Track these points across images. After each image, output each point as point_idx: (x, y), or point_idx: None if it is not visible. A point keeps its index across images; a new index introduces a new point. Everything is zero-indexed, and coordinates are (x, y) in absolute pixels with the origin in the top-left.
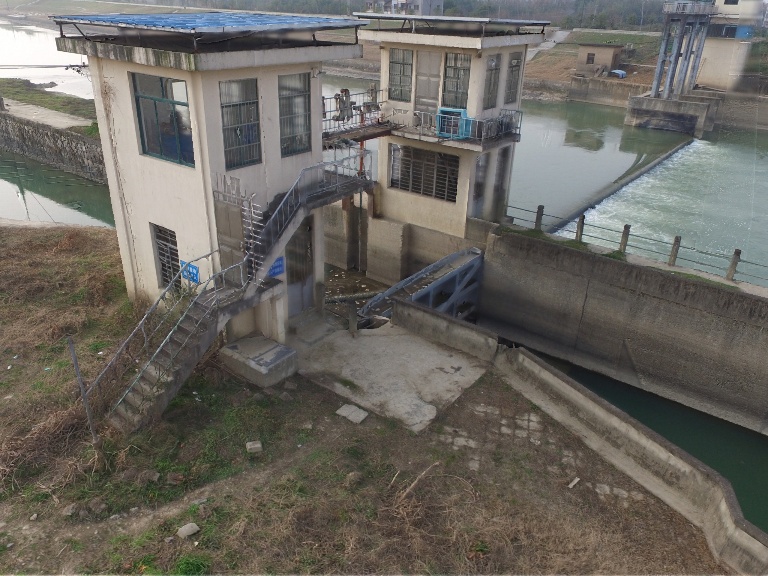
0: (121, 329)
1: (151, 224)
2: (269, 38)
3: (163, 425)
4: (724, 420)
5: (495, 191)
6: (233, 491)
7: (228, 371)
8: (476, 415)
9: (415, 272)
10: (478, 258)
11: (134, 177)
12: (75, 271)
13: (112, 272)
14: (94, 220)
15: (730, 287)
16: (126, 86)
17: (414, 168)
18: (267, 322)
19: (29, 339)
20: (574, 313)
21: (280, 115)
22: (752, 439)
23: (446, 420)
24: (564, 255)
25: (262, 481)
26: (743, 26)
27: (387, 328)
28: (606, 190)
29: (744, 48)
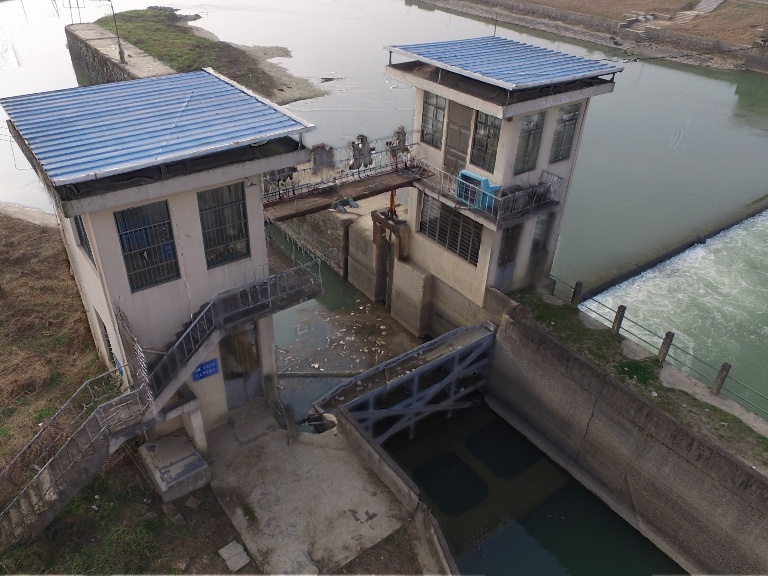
0: None
1: None
2: (175, 162)
3: (34, 548)
4: None
5: (533, 253)
6: None
7: (142, 471)
8: None
9: (436, 324)
10: (489, 336)
11: (78, 262)
12: (72, 305)
13: None
14: None
15: None
16: None
17: (441, 219)
18: None
19: None
20: (578, 427)
21: (203, 229)
22: None
23: None
24: (574, 364)
25: None
26: None
27: (329, 436)
28: (729, 218)
29: None
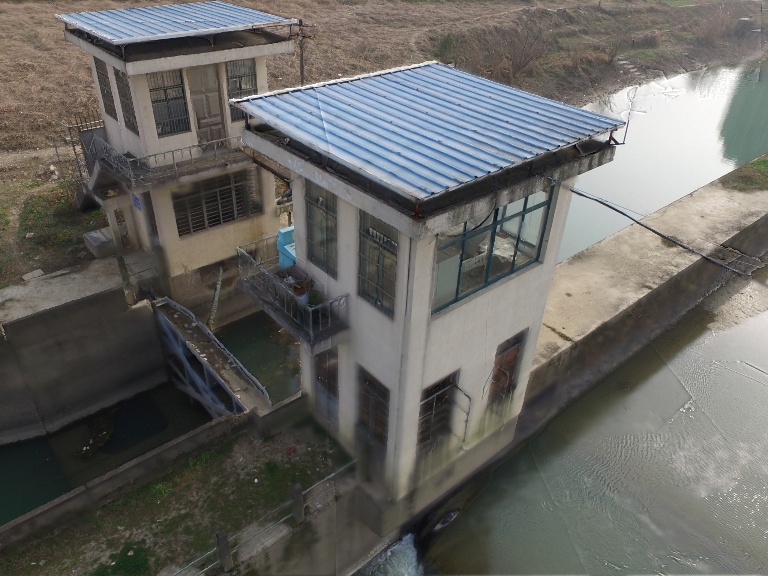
0: None
1: None
2: None
3: None
4: None
5: None
6: (7, 231)
7: None
8: None
9: None
10: None
11: None
12: None
13: None
14: None
15: None
16: None
17: None
18: (130, 230)
19: None
20: None
21: None
22: None
23: None
24: None
25: (6, 240)
26: None
27: None
28: None
29: None
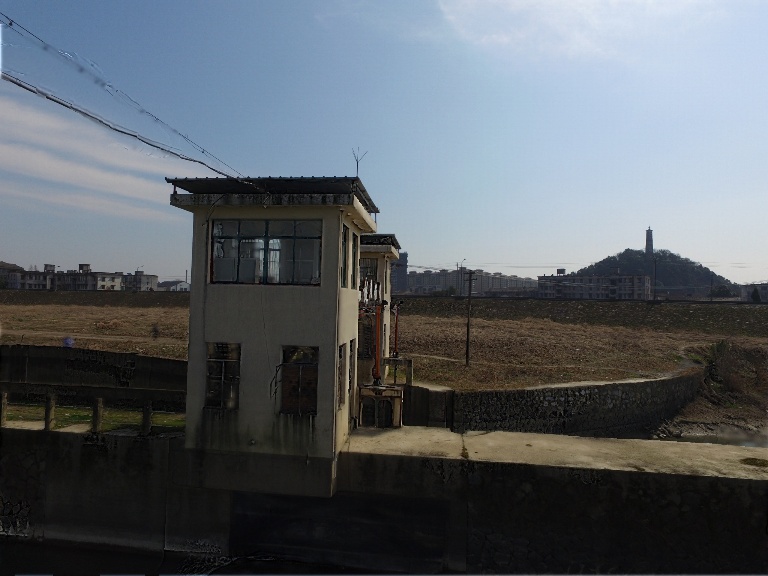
0: None
1: None
2: None
3: None
4: None
5: None
6: None
7: None
8: None
9: None
10: None
11: None
12: None
13: None
14: None
15: None
16: None
17: None
18: None
19: None
20: None
21: None
22: None
23: None
24: None
25: None
26: None
27: None
28: None
29: None
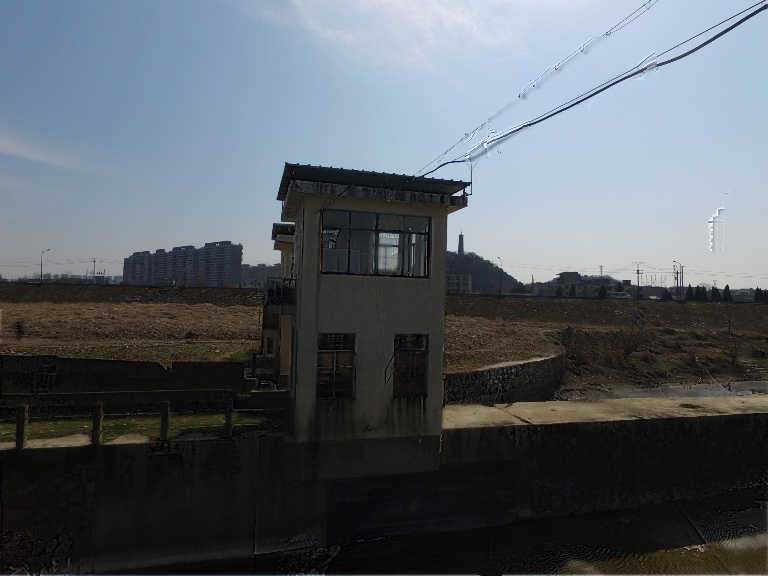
0: None
1: None
2: None
3: None
4: None
5: None
6: (220, 356)
7: None
8: None
9: None
10: None
11: None
12: None
13: None
14: None
15: None
16: None
17: None
18: (274, 353)
19: None
20: None
21: None
22: None
23: None
24: None
25: (216, 358)
26: None
27: None
28: None
29: None
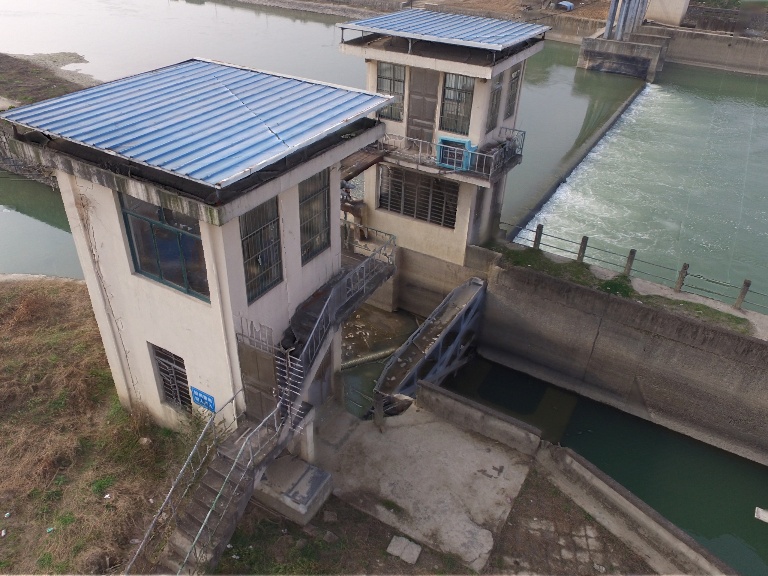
0: (122, 453)
1: (149, 342)
2: None
3: None
4: (733, 454)
5: (490, 208)
6: None
7: (258, 505)
8: (532, 536)
9: (407, 295)
10: (481, 290)
11: (125, 294)
12: (46, 362)
13: (90, 359)
14: (25, 216)
15: (740, 320)
16: (110, 202)
17: (406, 191)
18: None
19: (17, 484)
20: (584, 349)
21: (300, 223)
22: (760, 471)
23: (504, 547)
24: (575, 293)
25: None
26: (743, 20)
27: (413, 413)
28: (574, 158)
29: (743, 43)
